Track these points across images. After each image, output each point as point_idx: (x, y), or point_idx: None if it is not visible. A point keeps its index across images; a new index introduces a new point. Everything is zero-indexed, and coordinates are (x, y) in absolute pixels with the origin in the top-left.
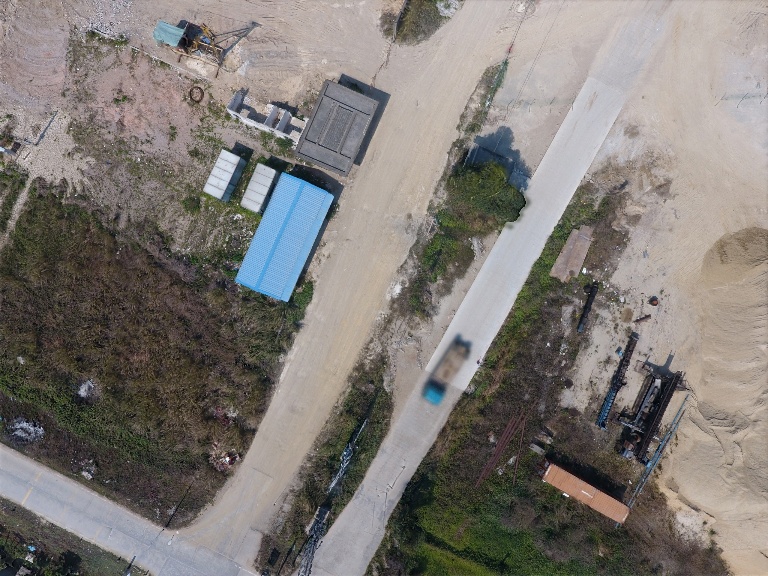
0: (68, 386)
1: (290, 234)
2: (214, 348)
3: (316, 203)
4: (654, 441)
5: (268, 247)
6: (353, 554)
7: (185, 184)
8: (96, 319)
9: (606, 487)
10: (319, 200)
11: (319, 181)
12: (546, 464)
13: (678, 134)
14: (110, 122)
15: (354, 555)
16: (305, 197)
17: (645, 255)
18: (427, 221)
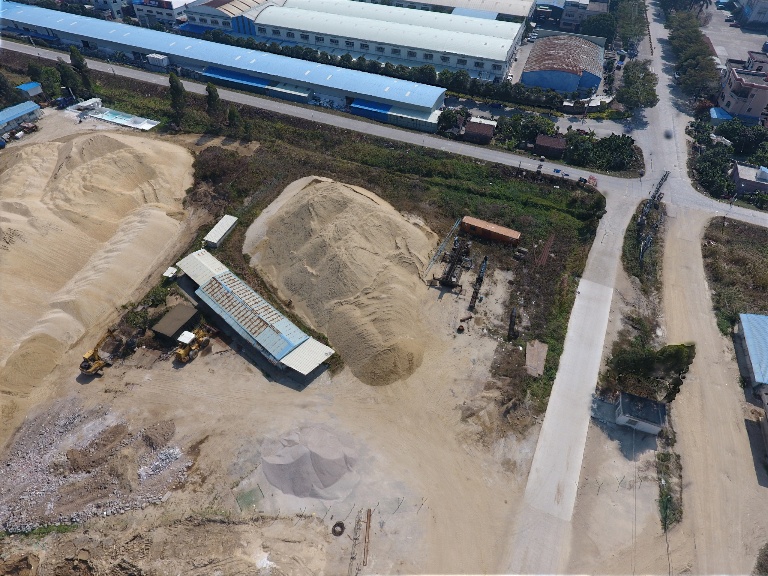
0: None
1: None
2: (762, 296)
3: (767, 374)
4: None
5: None
6: (612, 209)
7: None
8: None
9: None
10: (767, 376)
11: None
12: None
13: (462, 466)
14: None
15: (611, 208)
16: None
17: (474, 361)
18: None
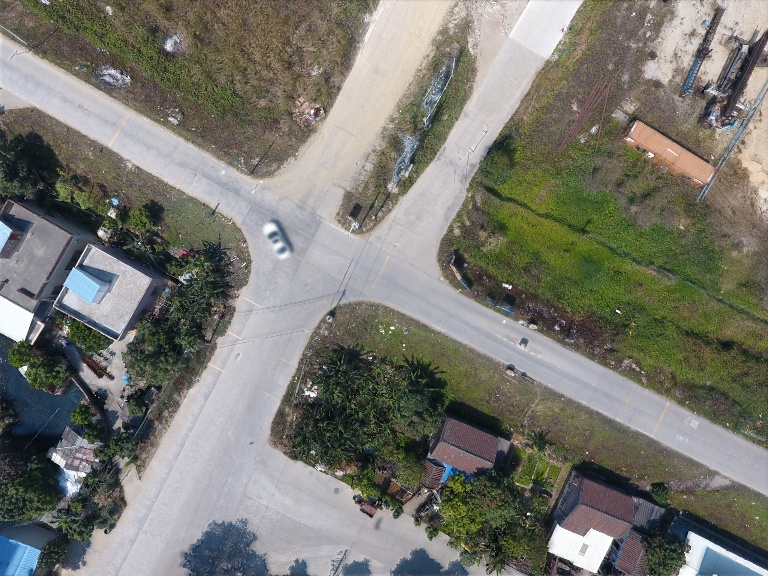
0: (155, 39)
1: None
2: (300, 5)
3: None
4: (738, 117)
5: None
6: (434, 214)
7: None
8: None
9: None
10: None
11: None
12: (631, 124)
13: None
14: None
15: (435, 215)
16: None
17: None
18: None
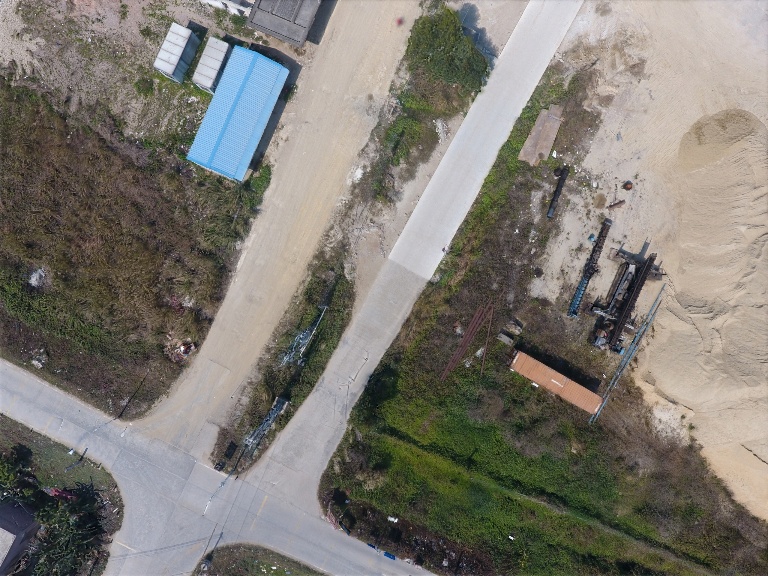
0: (18, 274)
1: (243, 109)
2: (168, 235)
3: (270, 77)
4: (629, 333)
5: (220, 122)
6: (313, 448)
7: (138, 65)
8: (47, 205)
9: (578, 380)
10: (274, 74)
11: (276, 61)
12: (514, 353)
13: (653, 11)
14: (60, 1)
15: (314, 449)
16: (259, 70)
17: (619, 138)
18: (389, 102)
